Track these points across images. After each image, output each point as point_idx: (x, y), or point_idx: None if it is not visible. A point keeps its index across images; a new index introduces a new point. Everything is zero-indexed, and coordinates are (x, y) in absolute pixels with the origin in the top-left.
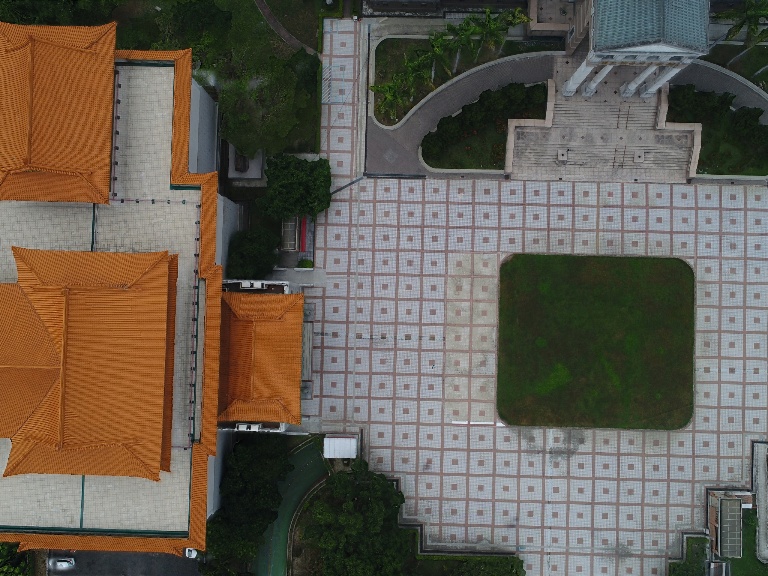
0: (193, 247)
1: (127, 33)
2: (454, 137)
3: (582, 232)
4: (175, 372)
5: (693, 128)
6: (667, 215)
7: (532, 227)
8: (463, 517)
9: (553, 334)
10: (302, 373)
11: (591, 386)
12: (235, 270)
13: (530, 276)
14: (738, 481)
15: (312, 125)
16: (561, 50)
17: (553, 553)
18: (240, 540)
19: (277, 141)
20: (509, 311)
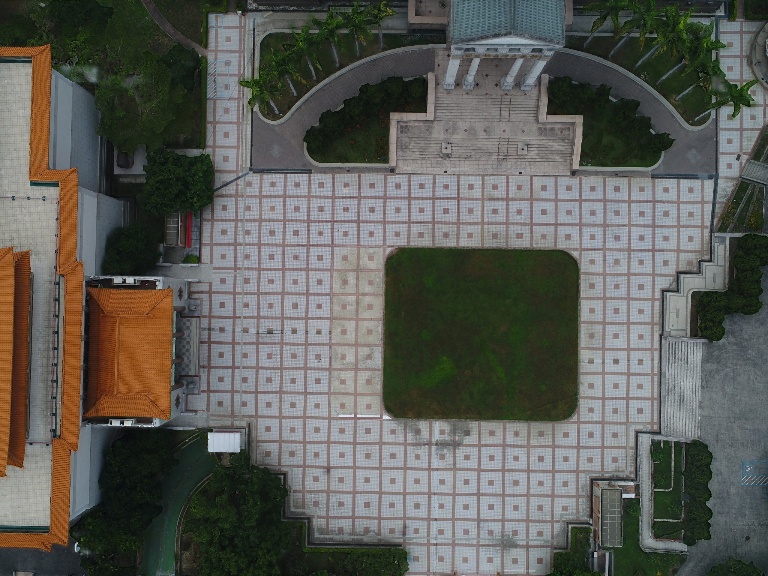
0: (54, 243)
1: (3, 30)
2: (335, 131)
3: (467, 225)
4: (37, 368)
5: (574, 120)
6: (551, 207)
7: (417, 220)
8: (350, 510)
9: (438, 327)
10: (189, 368)
11: (476, 378)
12: (111, 266)
13: (415, 269)
14: (622, 471)
15: (198, 120)
16: (442, 43)
17: (439, 544)
18: (122, 535)
19: (155, 137)
20: (394, 304)
